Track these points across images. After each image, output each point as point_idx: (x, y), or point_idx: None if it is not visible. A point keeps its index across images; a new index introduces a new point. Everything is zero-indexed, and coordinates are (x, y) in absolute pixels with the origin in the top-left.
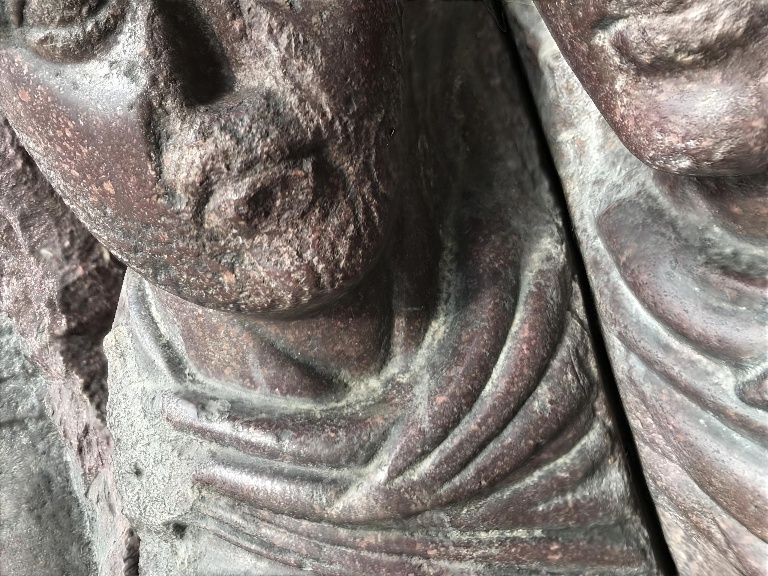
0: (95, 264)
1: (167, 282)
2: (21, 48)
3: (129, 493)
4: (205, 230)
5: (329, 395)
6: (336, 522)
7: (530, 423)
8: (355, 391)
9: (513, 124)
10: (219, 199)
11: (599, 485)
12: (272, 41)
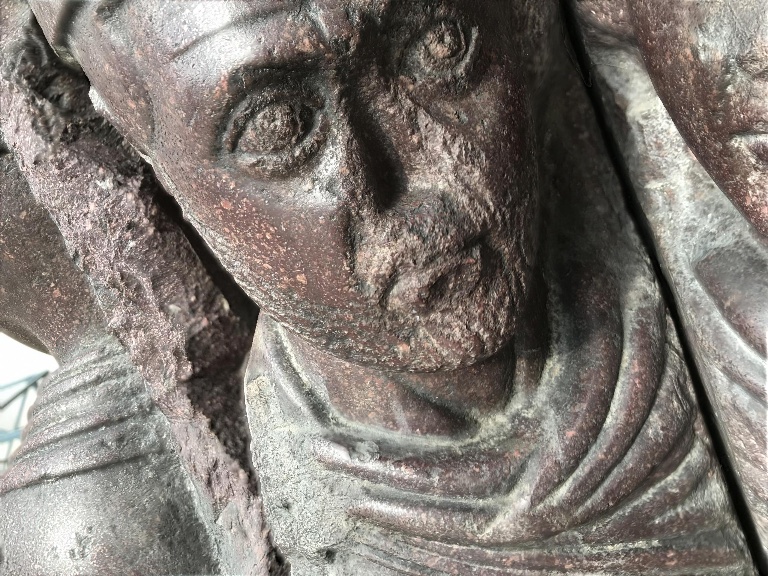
0: (217, 314)
1: (340, 351)
2: (230, 168)
3: (282, 525)
4: (388, 312)
5: (463, 432)
6: (485, 546)
7: (647, 449)
8: (485, 426)
9: (600, 170)
10: (404, 287)
11: (702, 496)
12: (446, 150)
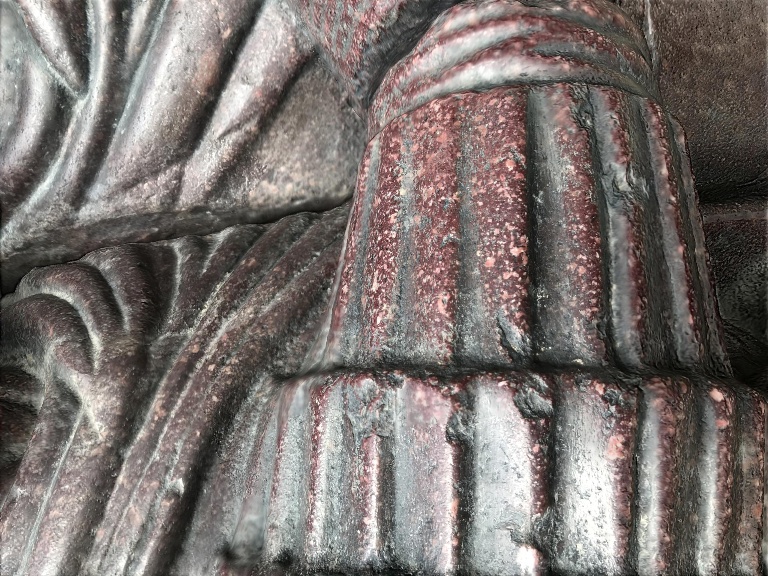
0: None
1: None
2: None
3: None
4: None
5: None
6: (124, 437)
7: (116, 269)
8: None
9: None
10: None
11: None
12: None
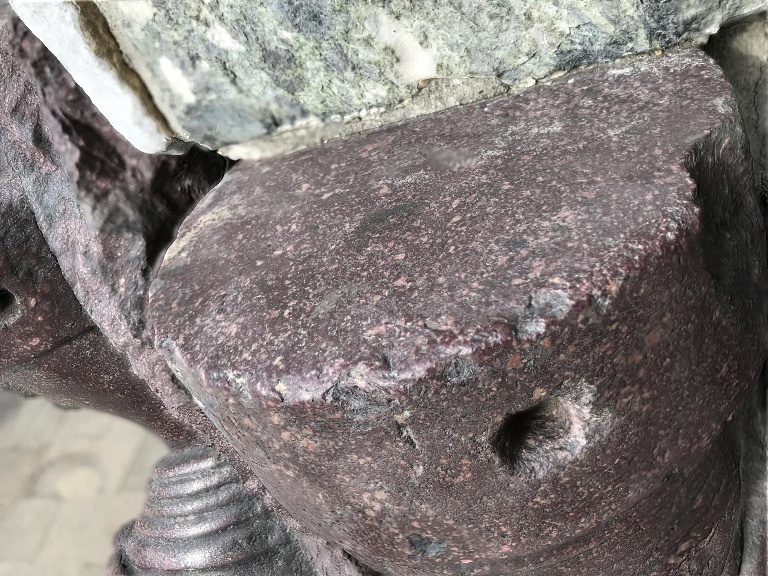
0: None
1: None
2: None
3: None
4: None
5: None
6: None
7: None
8: None
9: None
10: None
11: None
12: None
